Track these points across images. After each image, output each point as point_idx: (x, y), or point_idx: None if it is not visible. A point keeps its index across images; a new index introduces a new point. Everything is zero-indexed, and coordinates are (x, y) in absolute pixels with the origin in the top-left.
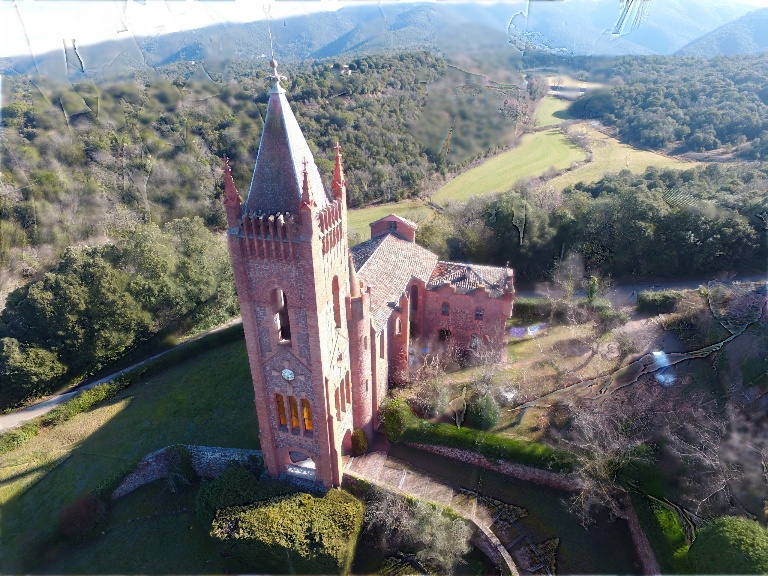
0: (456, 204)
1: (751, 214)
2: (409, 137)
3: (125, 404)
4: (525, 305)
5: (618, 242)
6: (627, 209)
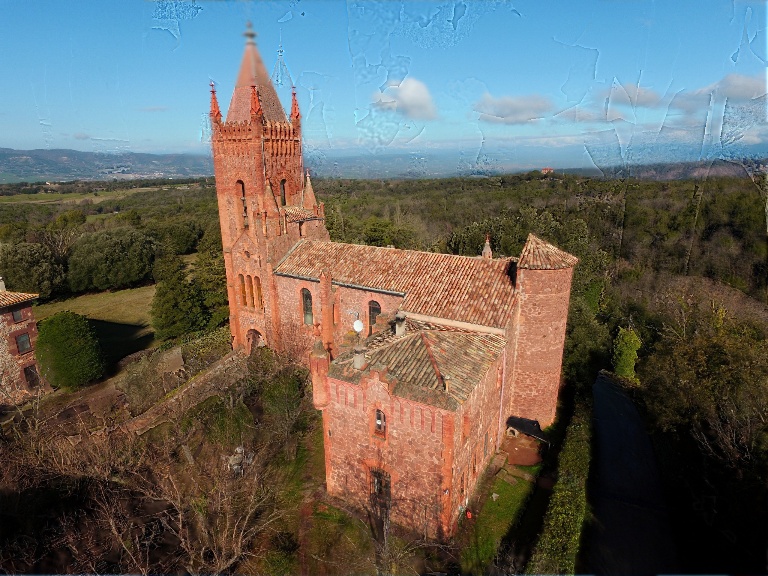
0: None
1: None
2: None
3: None
4: None
5: None
6: None
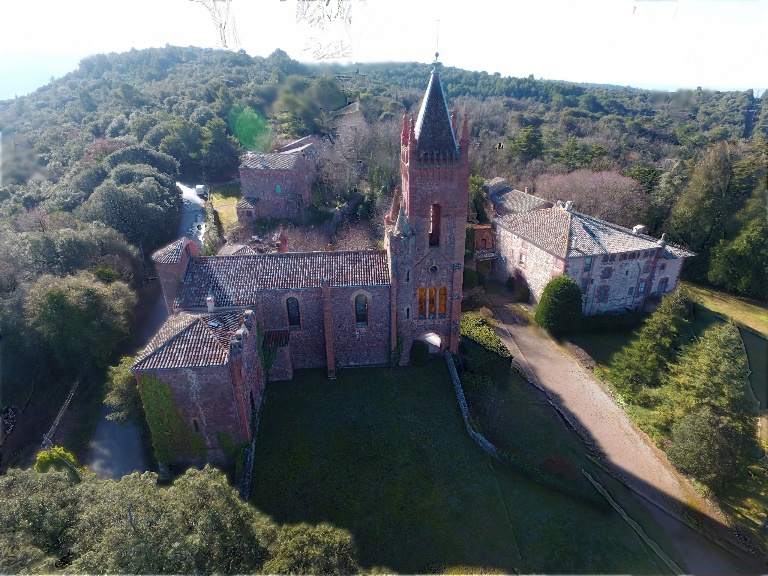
0: (4, 269)
1: (351, 132)
2: (341, 112)
3: (435, 572)
4: None
5: (144, 227)
6: (122, 202)
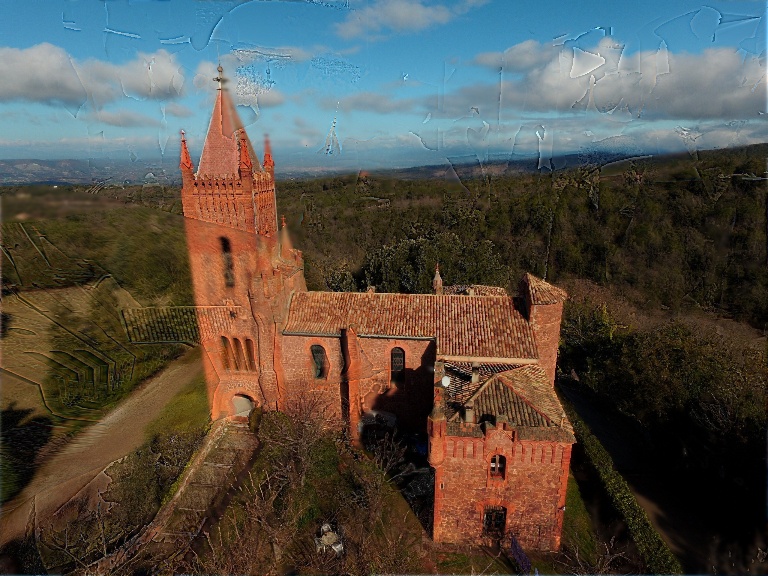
0: None
1: None
2: None
3: None
4: (649, 574)
5: None
6: None
